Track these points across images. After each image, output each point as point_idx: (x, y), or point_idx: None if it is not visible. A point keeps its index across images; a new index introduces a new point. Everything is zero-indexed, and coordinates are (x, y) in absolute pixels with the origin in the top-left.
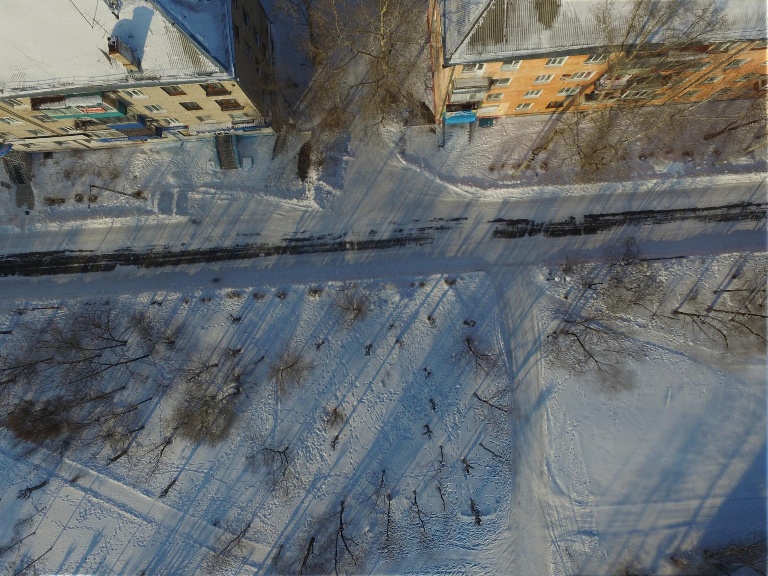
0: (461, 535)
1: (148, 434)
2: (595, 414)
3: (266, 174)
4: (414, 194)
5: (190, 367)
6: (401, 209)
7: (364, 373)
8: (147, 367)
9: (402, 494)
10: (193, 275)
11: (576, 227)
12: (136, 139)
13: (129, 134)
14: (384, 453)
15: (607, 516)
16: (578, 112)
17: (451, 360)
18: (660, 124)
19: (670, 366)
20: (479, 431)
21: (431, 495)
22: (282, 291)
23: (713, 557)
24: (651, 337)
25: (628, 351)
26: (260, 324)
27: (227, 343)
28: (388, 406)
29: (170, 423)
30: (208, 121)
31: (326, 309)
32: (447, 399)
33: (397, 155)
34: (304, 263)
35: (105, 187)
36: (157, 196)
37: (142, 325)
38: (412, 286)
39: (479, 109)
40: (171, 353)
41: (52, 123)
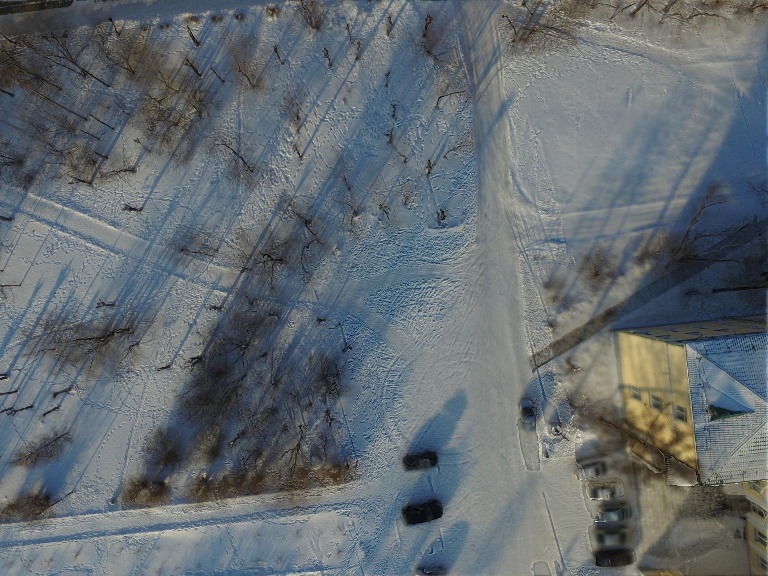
0: (429, 250)
1: (112, 164)
2: (557, 120)
3: None
4: None
5: (151, 96)
6: None
7: (325, 92)
8: (108, 98)
9: (368, 211)
10: (150, 5)
11: None
12: None
13: None
14: (349, 171)
15: (574, 223)
16: None
17: (412, 75)
18: None
19: (630, 68)
20: (442, 143)
21: (397, 210)
22: (240, 12)
23: (680, 250)
24: (610, 41)
25: (587, 55)
26: (219, 48)
27: (187, 70)
28: (351, 123)
29: (133, 152)
30: None
31: (285, 30)
32: (409, 113)
33: None
34: None
35: None
36: None
37: (101, 56)
38: (369, 0)
39: None
40: (131, 83)
41: None
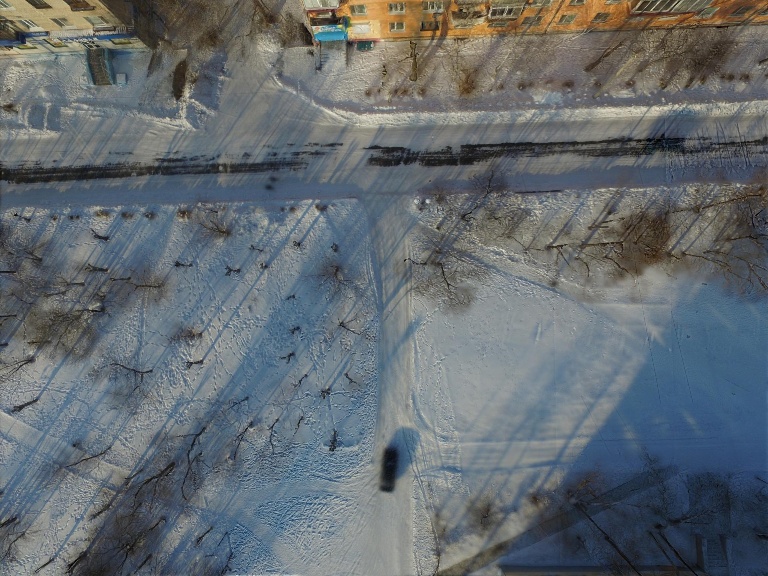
0: (323, 466)
1: (11, 351)
2: (463, 348)
3: (140, 92)
4: (289, 117)
5: (56, 285)
6: (276, 132)
7: (231, 298)
8: (13, 284)
9: (265, 422)
10: (63, 192)
11: (452, 157)
12: None
13: None
14: (248, 380)
15: (471, 453)
16: (459, 39)
17: (320, 288)
18: (517, 39)
19: (541, 302)
20: (345, 361)
21: (294, 424)
22: (151, 211)
23: (573, 496)
24: (523, 272)
25: (499, 285)
26: (128, 244)
27: (94, 262)
28: (254, 332)
29: None
30: (69, 27)
31: (195, 231)
32: (314, 327)
33: (274, 77)
34: (176, 184)
35: None
36: (28, 109)
37: (9, 241)
38: (282, 210)
39: (350, 27)
40: (37, 270)
41: None
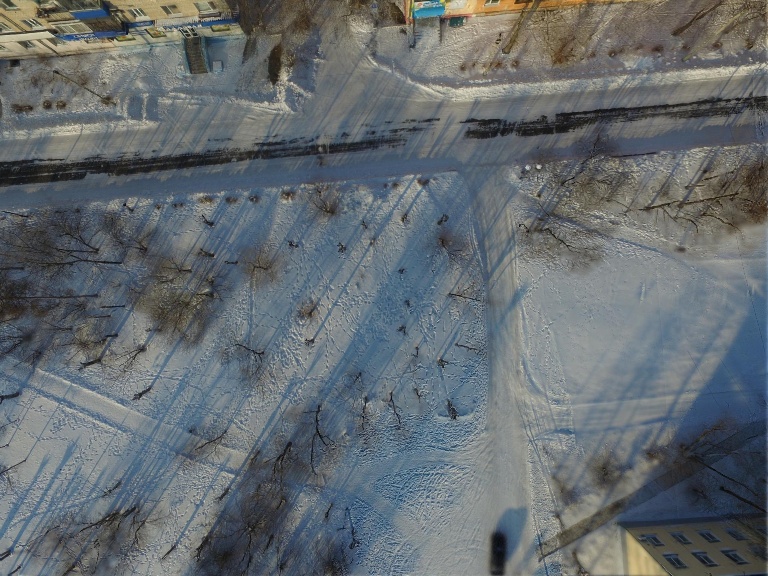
0: (439, 436)
1: (121, 342)
2: (570, 312)
3: (236, 78)
4: (386, 96)
5: (163, 274)
6: (373, 111)
7: (339, 276)
8: (119, 275)
9: (379, 396)
10: (164, 182)
11: (548, 126)
12: (102, 37)
13: (94, 28)
14: (360, 356)
15: (584, 414)
16: (548, 10)
17: (426, 261)
18: None
19: (643, 262)
20: (455, 331)
21: (408, 397)
22: (254, 194)
23: (688, 449)
24: (624, 234)
25: (601, 248)
26: (233, 229)
27: None
28: (363, 308)
29: (144, 330)
30: (174, 15)
31: (299, 212)
32: (422, 300)
33: (368, 57)
34: (276, 167)
35: (73, 93)
36: (126, 101)
37: (113, 232)
38: (385, 187)
39: (448, 3)
40: (143, 260)
41: (14, 13)
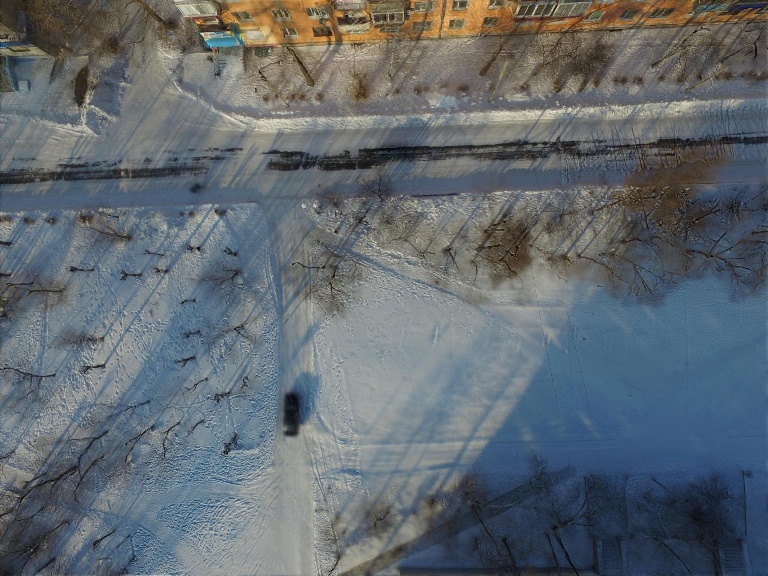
0: (225, 469)
1: None
2: (361, 351)
3: (43, 98)
4: (189, 123)
5: None
6: (176, 138)
7: (132, 302)
8: None
9: (166, 425)
10: None
11: (350, 161)
12: None
13: None
14: (150, 383)
15: (371, 455)
16: (355, 44)
17: (220, 292)
18: None
19: (438, 305)
20: (245, 364)
21: (195, 427)
22: (52, 216)
23: (469, 498)
24: (421, 275)
25: (397, 288)
26: (30, 249)
27: None
28: (155, 336)
29: None
30: None
31: (97, 236)
32: (214, 331)
33: (174, 83)
34: (78, 189)
35: None
36: None
37: None
38: (182, 215)
39: (243, 34)
40: None
41: None
